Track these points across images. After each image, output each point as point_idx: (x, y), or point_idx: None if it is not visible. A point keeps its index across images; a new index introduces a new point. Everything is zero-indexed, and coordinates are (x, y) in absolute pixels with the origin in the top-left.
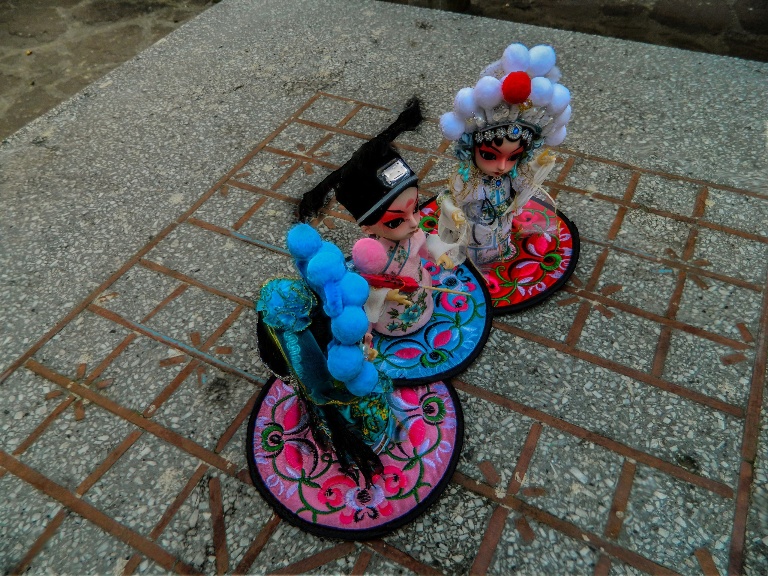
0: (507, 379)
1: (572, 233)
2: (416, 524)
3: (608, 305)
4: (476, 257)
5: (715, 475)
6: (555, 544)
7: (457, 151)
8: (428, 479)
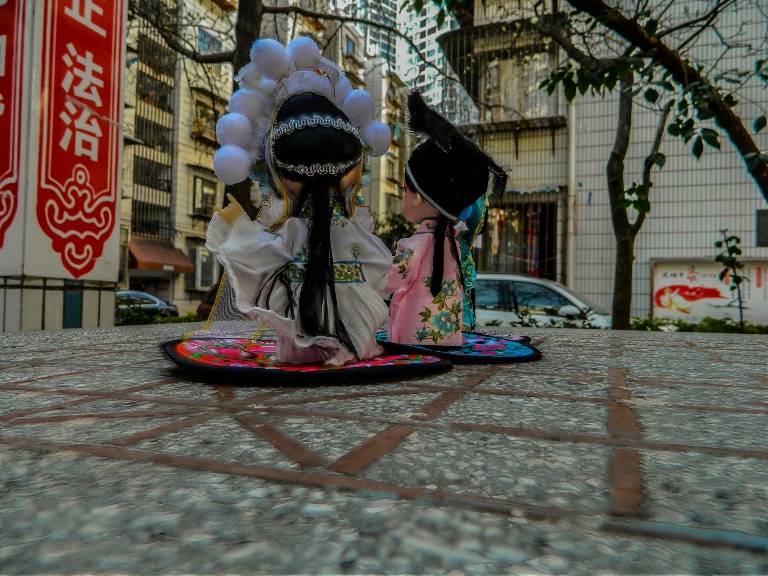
0: None
1: None
2: None
3: None
4: None
5: None
6: None
7: None
8: None
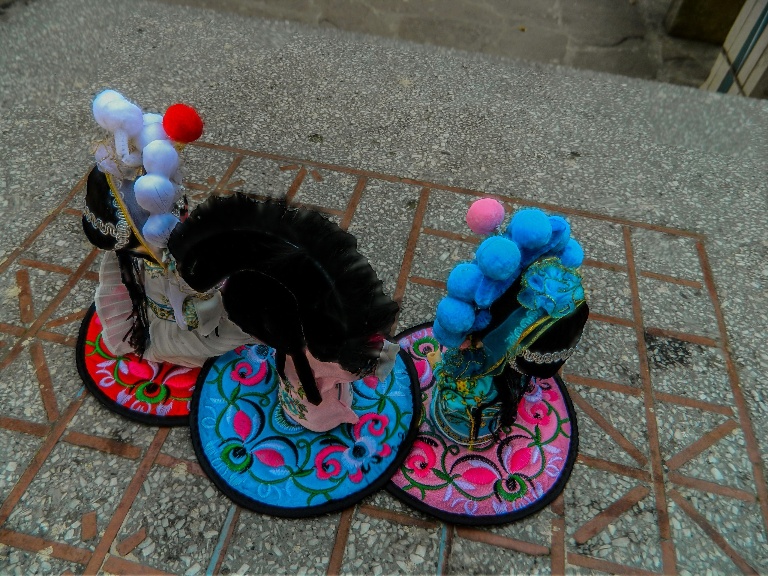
0: None
1: None
2: None
3: None
4: None
5: (416, 194)
6: None
7: None
8: None
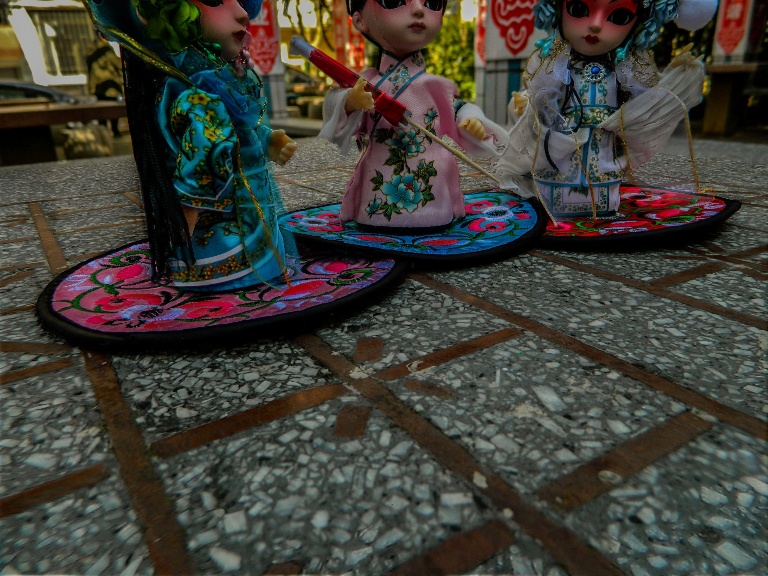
0: (506, 288)
1: (729, 204)
2: (181, 360)
3: (766, 271)
4: (551, 200)
5: None
6: (394, 462)
7: (537, 10)
8: (254, 313)
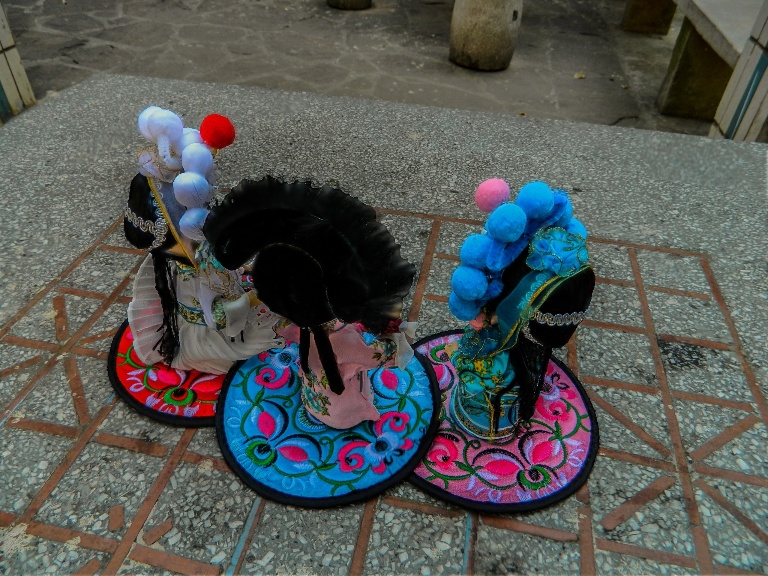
0: None
1: None
2: None
3: None
4: None
5: (428, 225)
6: None
7: (209, 247)
8: None
